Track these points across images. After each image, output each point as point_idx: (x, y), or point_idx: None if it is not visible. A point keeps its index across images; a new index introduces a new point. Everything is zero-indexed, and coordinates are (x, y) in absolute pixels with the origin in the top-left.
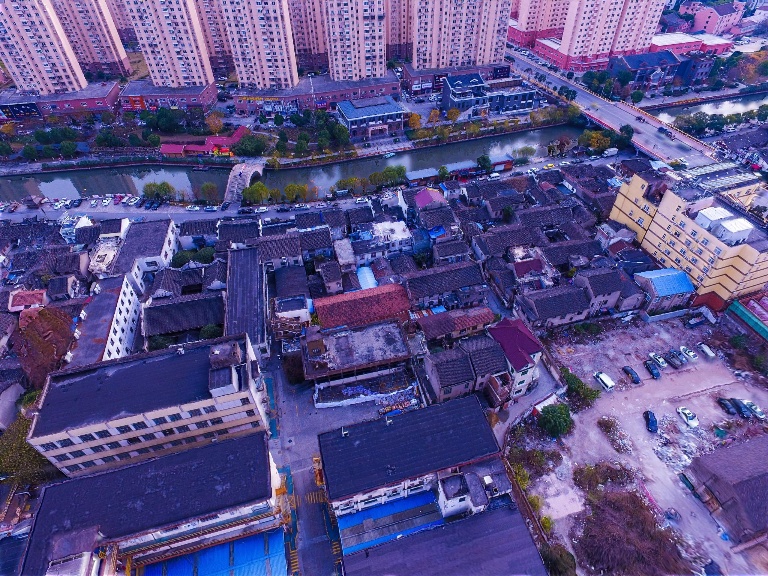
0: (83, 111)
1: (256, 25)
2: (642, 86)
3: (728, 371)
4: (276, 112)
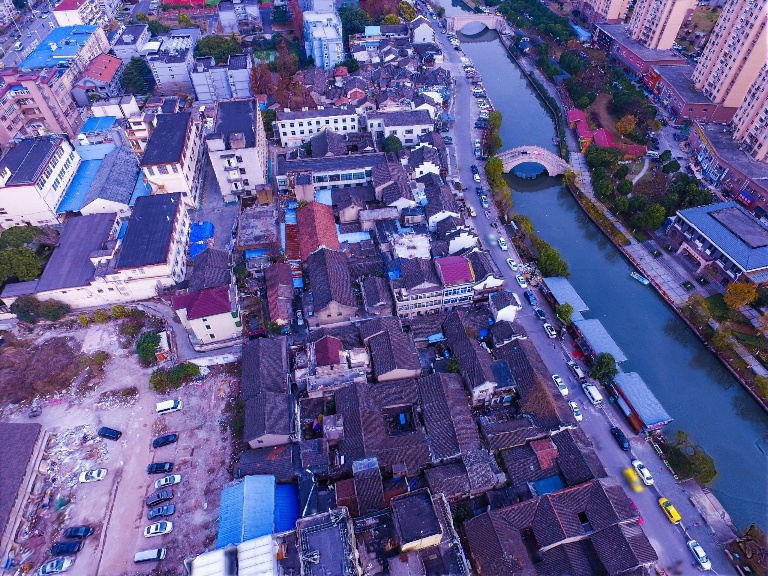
0: (626, 63)
1: None
2: None
3: (114, 575)
4: None
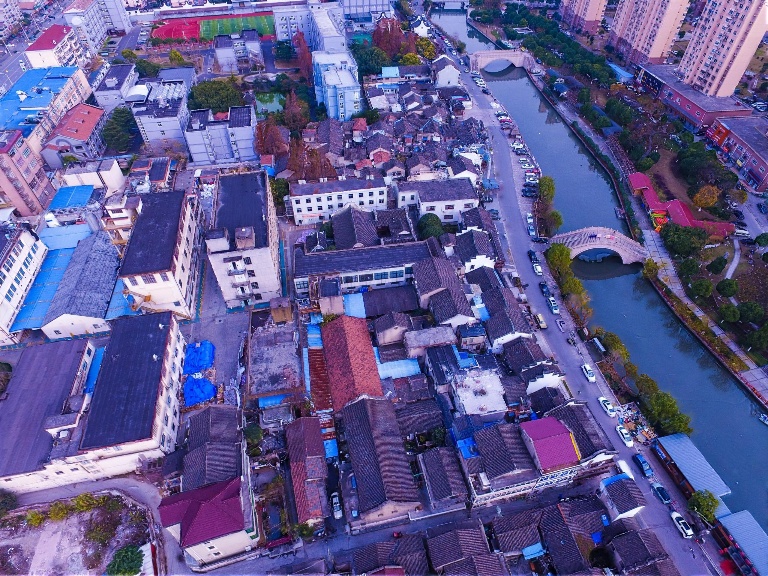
0: (681, 112)
1: None
2: None
3: None
4: None
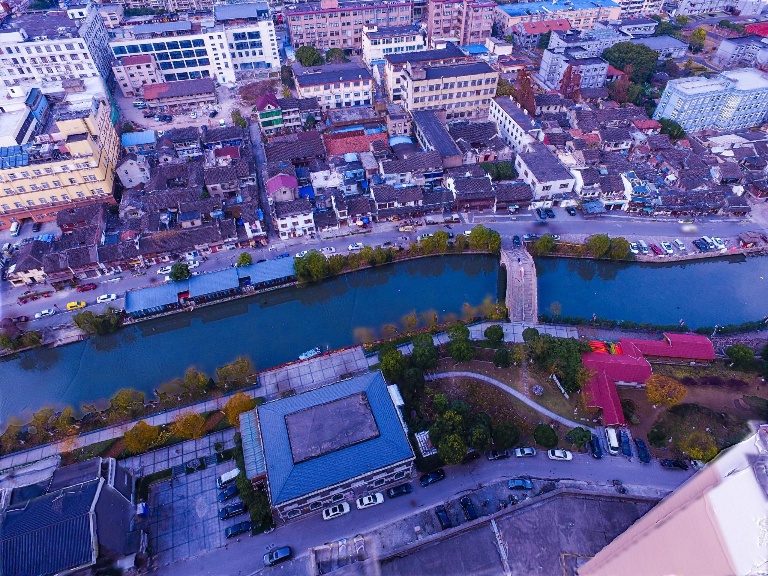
0: None
1: None
2: None
3: None
4: None
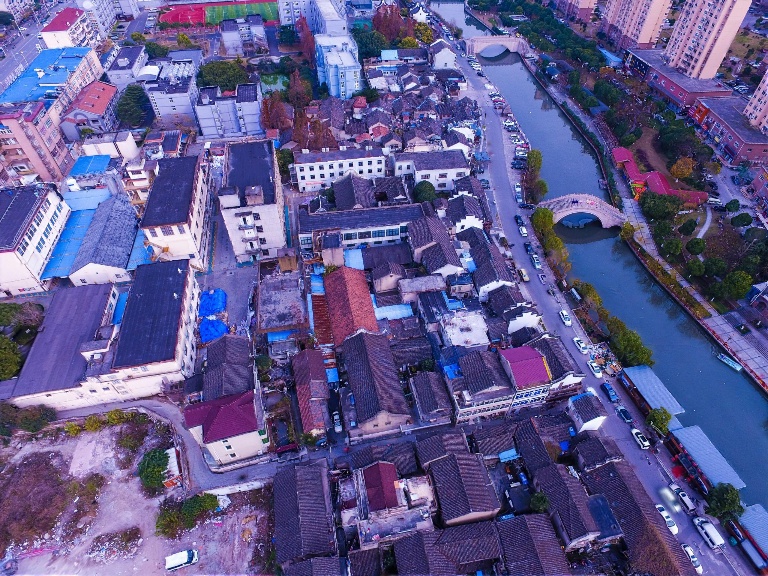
0: (666, 93)
1: None
2: None
3: None
4: None
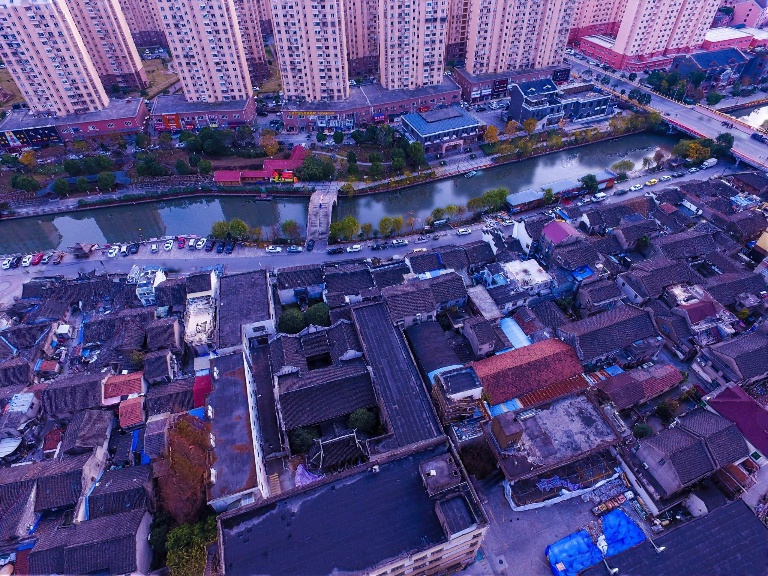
0: (110, 133)
1: (310, 31)
2: (709, 86)
3: None
4: (330, 127)
